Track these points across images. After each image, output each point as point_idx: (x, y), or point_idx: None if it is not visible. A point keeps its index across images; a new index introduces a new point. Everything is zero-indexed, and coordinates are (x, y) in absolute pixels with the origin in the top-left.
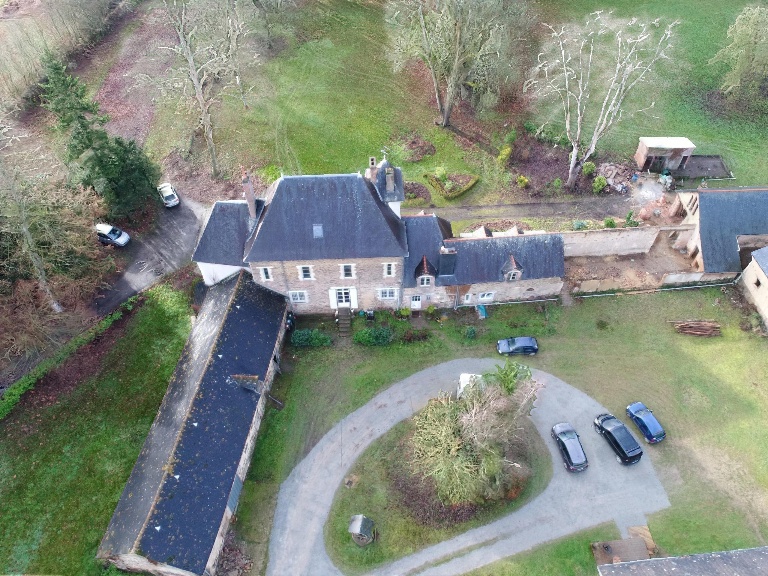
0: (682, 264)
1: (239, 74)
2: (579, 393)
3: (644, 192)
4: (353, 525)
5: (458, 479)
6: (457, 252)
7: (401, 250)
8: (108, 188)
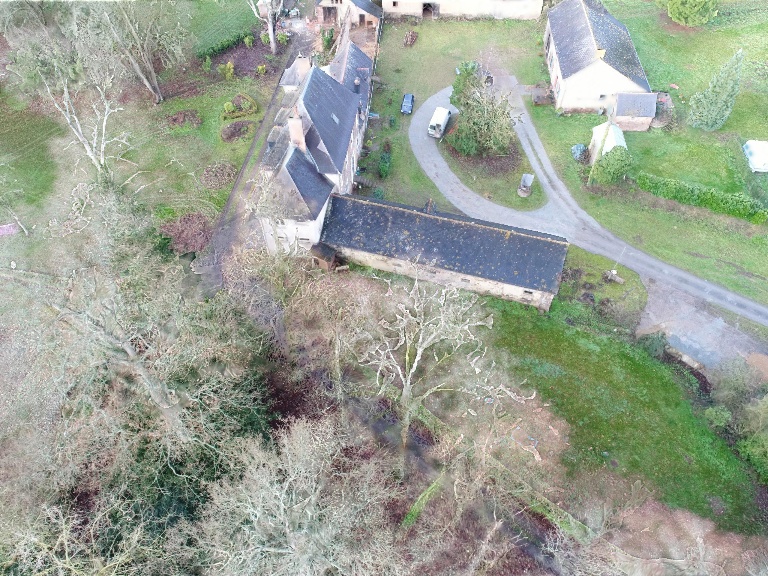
0: (363, 30)
1: (4, 202)
2: (444, 90)
3: (297, 26)
4: (528, 181)
5: (515, 117)
6: (349, 87)
7: (356, 94)
8: (181, 289)
